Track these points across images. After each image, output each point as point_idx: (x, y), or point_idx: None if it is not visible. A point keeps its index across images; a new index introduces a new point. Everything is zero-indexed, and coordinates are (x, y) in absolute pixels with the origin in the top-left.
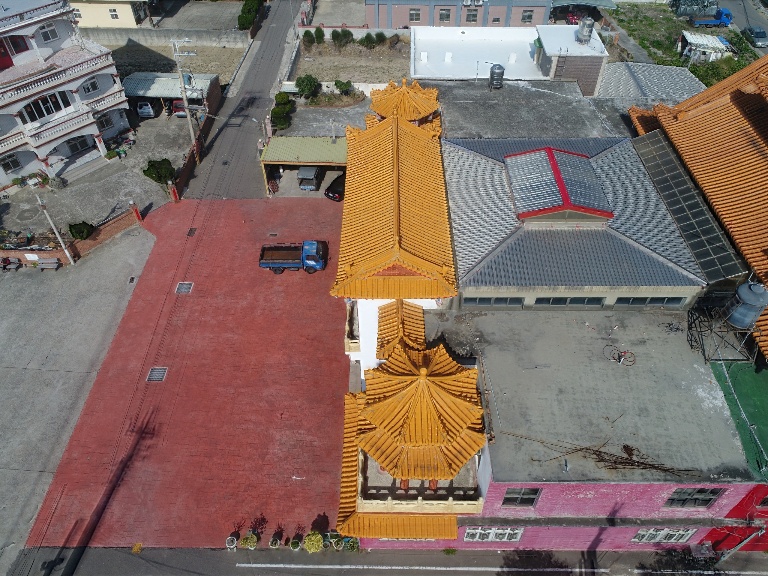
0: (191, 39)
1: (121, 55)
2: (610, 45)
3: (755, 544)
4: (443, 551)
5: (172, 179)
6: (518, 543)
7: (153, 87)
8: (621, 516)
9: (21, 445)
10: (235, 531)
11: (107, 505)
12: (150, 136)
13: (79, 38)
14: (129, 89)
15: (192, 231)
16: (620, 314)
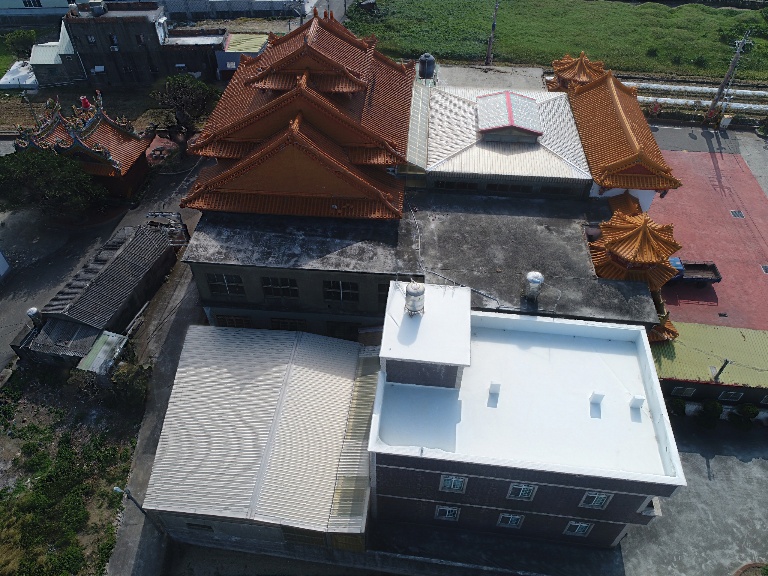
0: None
1: None
2: None
3: None
4: None
5: None
6: None
7: None
8: None
9: None
10: None
11: None
12: None
13: None
14: None
15: None
16: None
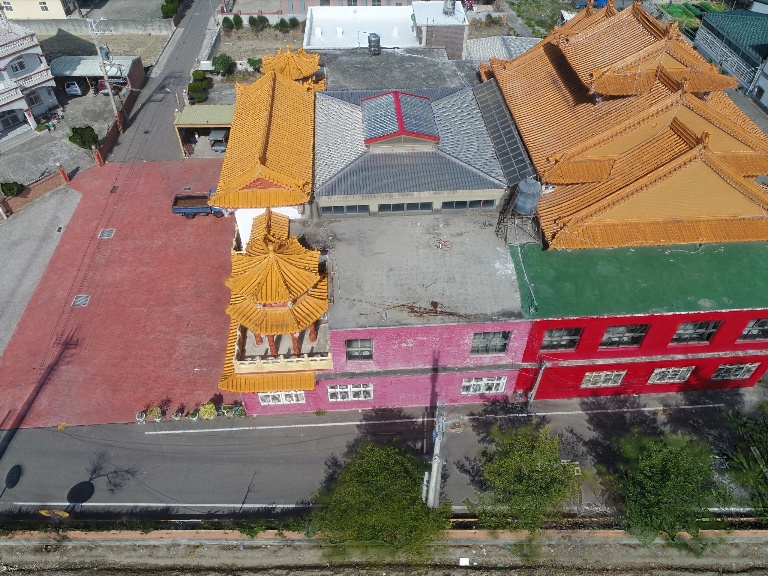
0: (118, 28)
1: (52, 44)
2: (499, 25)
3: (558, 391)
4: (315, 413)
5: (96, 144)
6: (373, 401)
7: (79, 68)
8: (443, 365)
9: None
10: (145, 410)
11: (36, 398)
12: (78, 112)
13: (6, 22)
14: (56, 70)
15: (115, 188)
16: (447, 216)
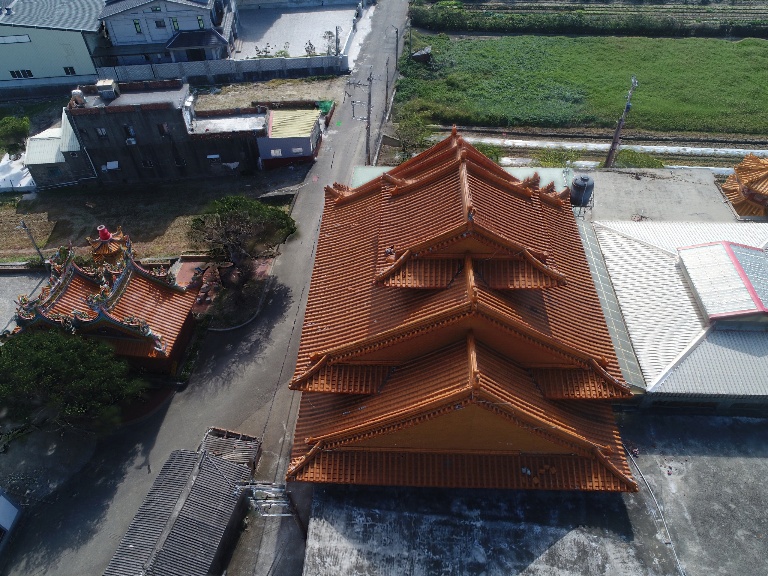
0: None
1: None
2: None
3: None
4: None
5: None
6: None
7: None
8: None
9: None
10: None
11: None
12: None
13: None
14: None
15: None
16: None
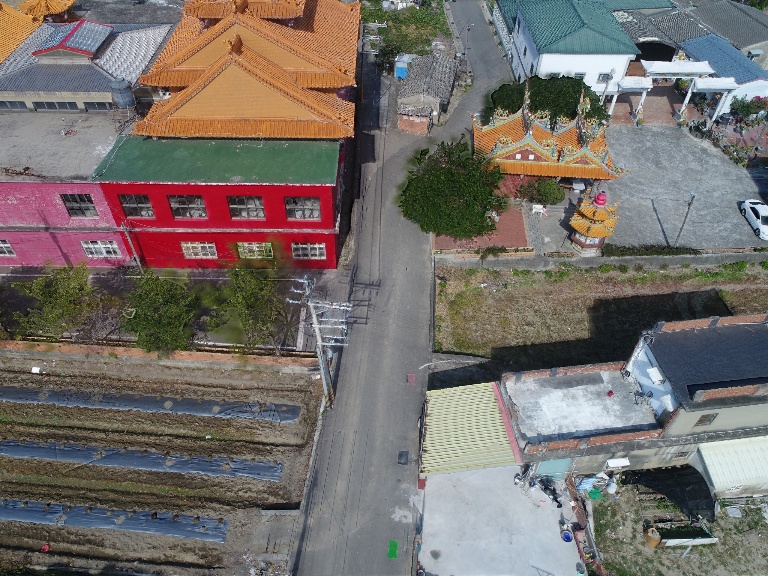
0: None
1: None
2: None
3: (168, 260)
4: None
5: None
6: (18, 258)
7: None
8: (54, 225)
9: None
10: None
11: None
12: None
13: None
14: None
15: None
16: (90, 115)
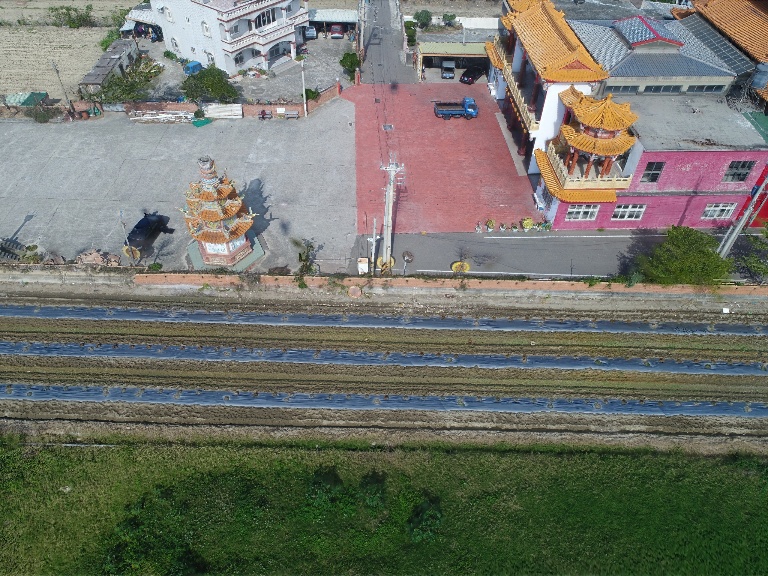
0: None
1: None
2: None
3: (766, 219)
4: (597, 230)
5: None
6: (640, 222)
7: (317, 15)
8: (700, 190)
9: (328, 196)
10: None
11: (396, 218)
12: (318, 49)
13: None
14: None
15: (377, 100)
16: (690, 97)
